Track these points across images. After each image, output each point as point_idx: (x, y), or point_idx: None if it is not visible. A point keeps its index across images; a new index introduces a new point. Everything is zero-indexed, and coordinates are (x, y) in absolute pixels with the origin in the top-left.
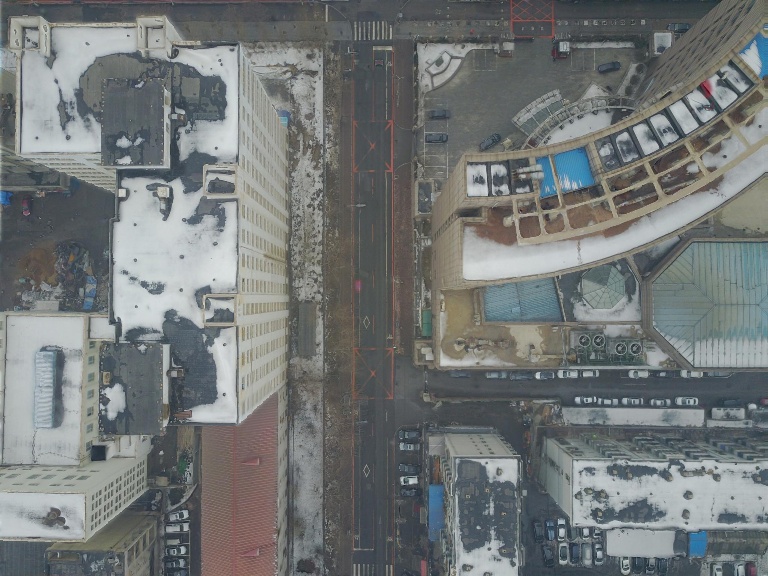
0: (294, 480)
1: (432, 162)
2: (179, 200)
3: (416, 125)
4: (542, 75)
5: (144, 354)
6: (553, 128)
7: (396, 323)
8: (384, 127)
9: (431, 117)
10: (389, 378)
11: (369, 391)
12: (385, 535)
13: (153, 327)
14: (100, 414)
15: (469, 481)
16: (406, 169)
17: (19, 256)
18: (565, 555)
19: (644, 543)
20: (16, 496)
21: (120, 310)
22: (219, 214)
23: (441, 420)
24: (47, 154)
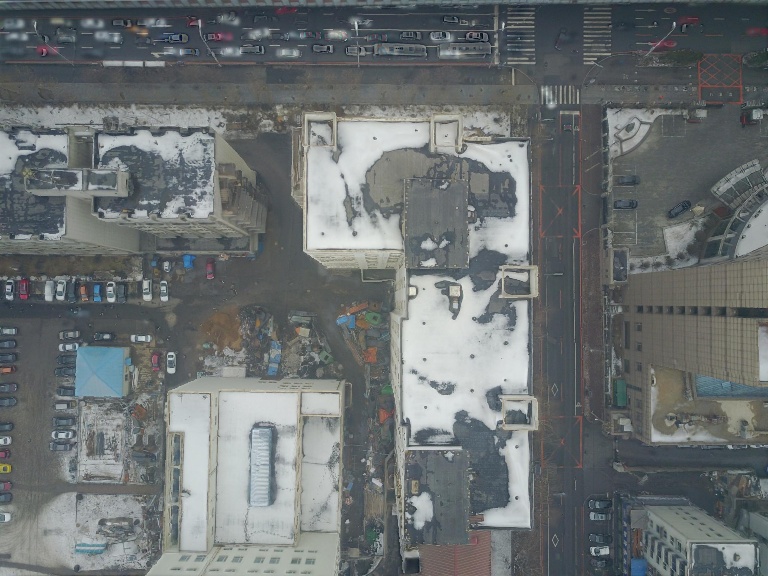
0: None
1: (620, 228)
2: (469, 298)
3: (607, 191)
4: (731, 141)
5: (451, 462)
6: (764, 201)
7: (588, 392)
8: (572, 192)
9: (621, 183)
10: (577, 446)
11: (558, 459)
12: None
13: (443, 428)
14: (406, 523)
15: (706, 567)
16: (594, 235)
17: (201, 320)
18: None
19: None
20: None
21: (409, 411)
22: (510, 313)
23: (631, 489)
24: (335, 251)
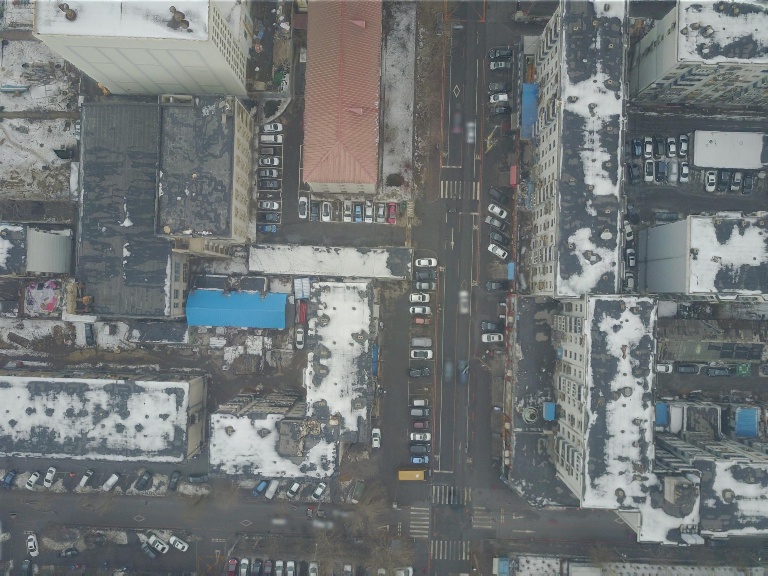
0: (385, 98)
1: None
2: None
3: None
4: None
5: None
6: None
7: None
8: None
9: None
10: (481, 2)
11: (461, 13)
12: (473, 154)
13: None
14: None
15: (577, 16)
16: None
17: None
18: (651, 170)
19: (731, 153)
20: None
21: None
22: None
23: None
24: None
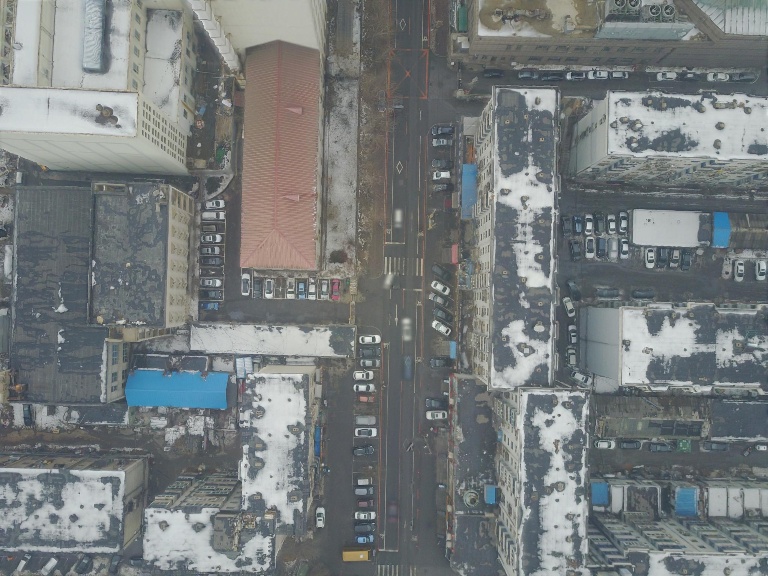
0: (329, 174)
1: None
2: None
3: None
4: None
5: None
6: None
7: (432, 20)
8: None
9: None
10: (423, 79)
11: (404, 90)
12: (416, 230)
13: None
14: None
15: (508, 109)
16: None
17: None
18: (592, 247)
19: (669, 232)
20: (70, 94)
21: None
22: None
23: None
24: None
